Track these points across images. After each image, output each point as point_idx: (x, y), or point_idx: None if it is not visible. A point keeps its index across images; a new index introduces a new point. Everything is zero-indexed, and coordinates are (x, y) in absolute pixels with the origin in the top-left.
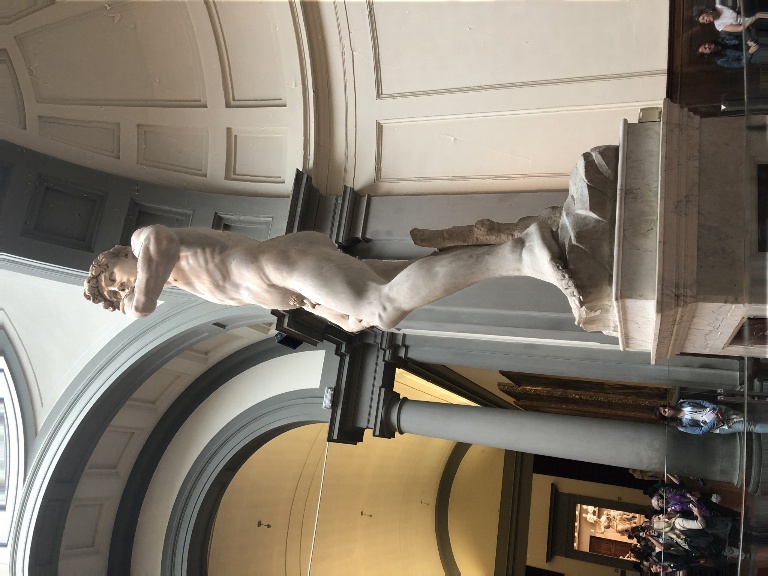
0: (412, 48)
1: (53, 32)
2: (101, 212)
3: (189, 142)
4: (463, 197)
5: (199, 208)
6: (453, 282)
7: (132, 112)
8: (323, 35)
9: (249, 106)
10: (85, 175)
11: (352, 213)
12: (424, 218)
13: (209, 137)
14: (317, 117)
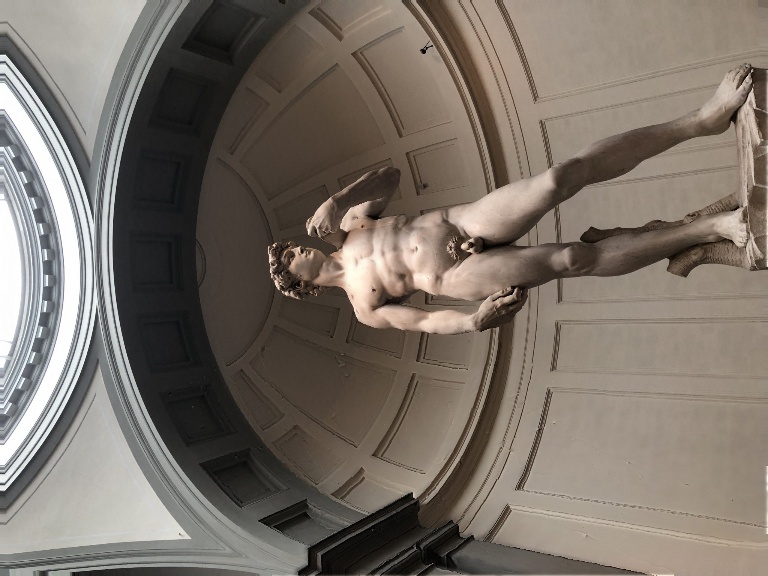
0: (567, 464)
1: (296, 345)
2: (220, 437)
3: (322, 462)
4: (583, 563)
5: (295, 489)
6: (632, 132)
7: (300, 416)
8: (490, 433)
9: (392, 463)
10: (235, 411)
11: (447, 539)
12: (529, 563)
13: (342, 465)
14: (452, 480)
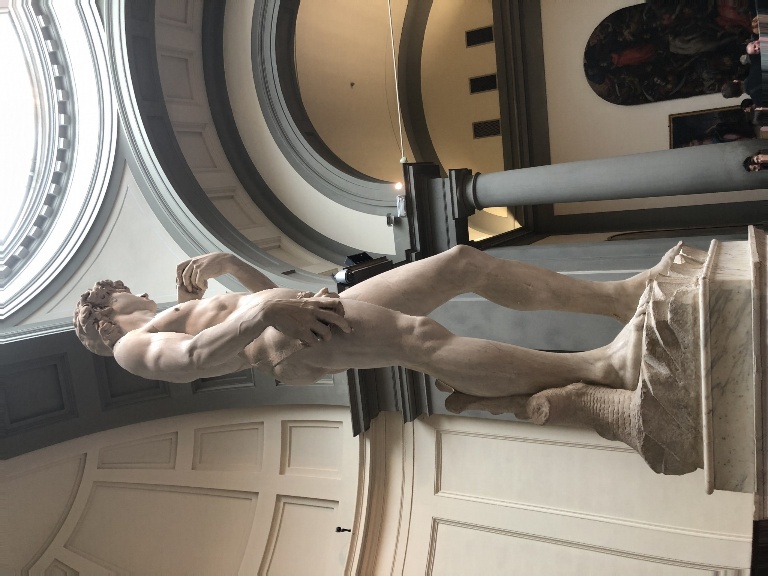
0: None
1: None
2: None
3: None
4: None
5: None
6: None
7: None
8: None
9: None
10: None
11: None
12: None
13: None
14: None
